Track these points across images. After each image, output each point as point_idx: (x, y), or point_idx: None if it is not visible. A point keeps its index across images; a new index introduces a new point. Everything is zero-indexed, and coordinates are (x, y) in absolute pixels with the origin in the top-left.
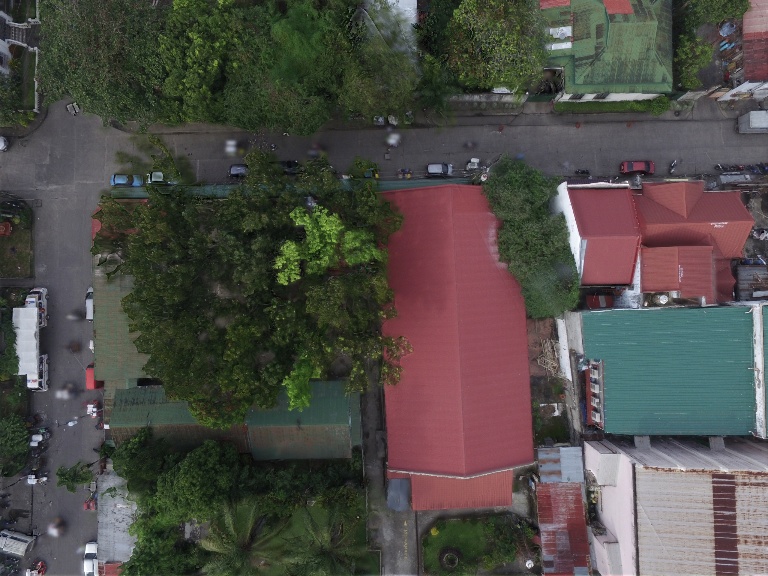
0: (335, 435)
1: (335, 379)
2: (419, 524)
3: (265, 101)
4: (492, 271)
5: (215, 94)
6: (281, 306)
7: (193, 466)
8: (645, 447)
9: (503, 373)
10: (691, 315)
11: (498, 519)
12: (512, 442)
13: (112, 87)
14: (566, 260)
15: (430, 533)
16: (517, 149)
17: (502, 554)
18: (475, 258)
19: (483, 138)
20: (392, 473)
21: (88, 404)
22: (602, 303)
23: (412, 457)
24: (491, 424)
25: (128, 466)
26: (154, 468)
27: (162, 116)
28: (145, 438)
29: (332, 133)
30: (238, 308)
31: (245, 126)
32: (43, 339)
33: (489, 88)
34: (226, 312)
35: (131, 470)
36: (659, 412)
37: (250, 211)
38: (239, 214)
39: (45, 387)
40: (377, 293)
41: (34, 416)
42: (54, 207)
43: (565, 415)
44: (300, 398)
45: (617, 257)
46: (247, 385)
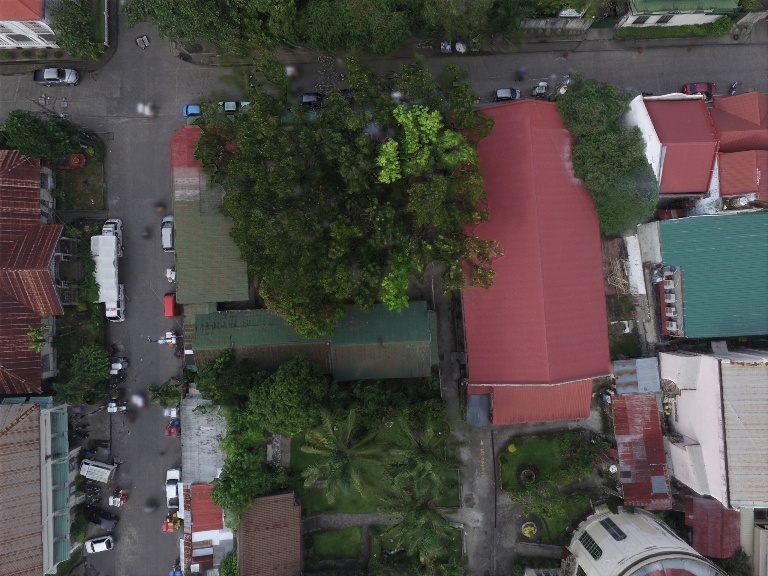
0: (416, 353)
1: (412, 300)
2: (495, 443)
3: (350, 17)
4: (568, 186)
5: (300, 11)
6: (380, 207)
7: (288, 375)
8: (723, 351)
9: (581, 286)
10: (767, 218)
11: (573, 435)
12: (591, 353)
13: (200, 4)
14: (644, 170)
15: (507, 450)
16: (582, 75)
17: (580, 466)
18: (552, 173)
19: (548, 64)
20: (472, 389)
21: (167, 332)
22: (674, 216)
23: (494, 370)
24: (571, 335)
25: (218, 382)
26: (245, 382)
27: (246, 35)
28: (229, 359)
29: (401, 61)
30: (338, 210)
31: (326, 46)
32: (120, 269)
33: (557, 12)
34: (326, 215)
35: (222, 385)
36: (738, 314)
37: (353, 110)
38: (341, 114)
39: (122, 317)
40: (474, 193)
41: (112, 346)
42: (126, 140)
43: (636, 332)
44: (400, 298)
45: (695, 164)
46: (350, 284)
